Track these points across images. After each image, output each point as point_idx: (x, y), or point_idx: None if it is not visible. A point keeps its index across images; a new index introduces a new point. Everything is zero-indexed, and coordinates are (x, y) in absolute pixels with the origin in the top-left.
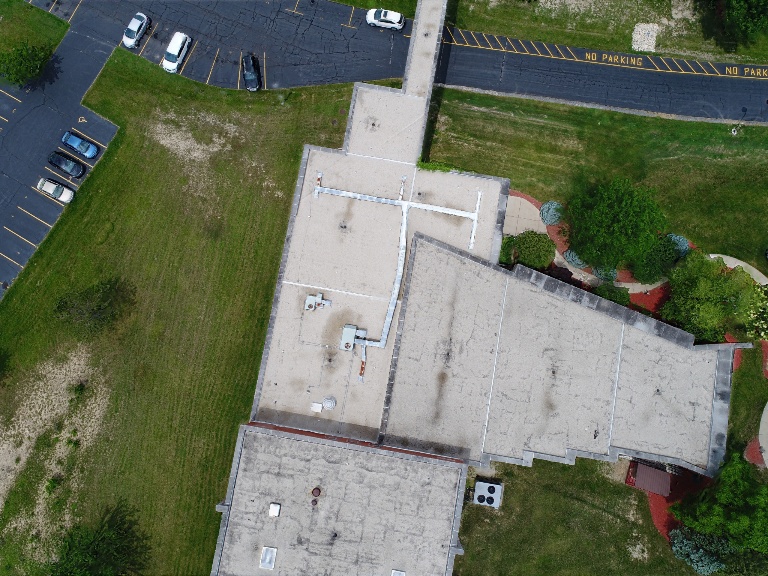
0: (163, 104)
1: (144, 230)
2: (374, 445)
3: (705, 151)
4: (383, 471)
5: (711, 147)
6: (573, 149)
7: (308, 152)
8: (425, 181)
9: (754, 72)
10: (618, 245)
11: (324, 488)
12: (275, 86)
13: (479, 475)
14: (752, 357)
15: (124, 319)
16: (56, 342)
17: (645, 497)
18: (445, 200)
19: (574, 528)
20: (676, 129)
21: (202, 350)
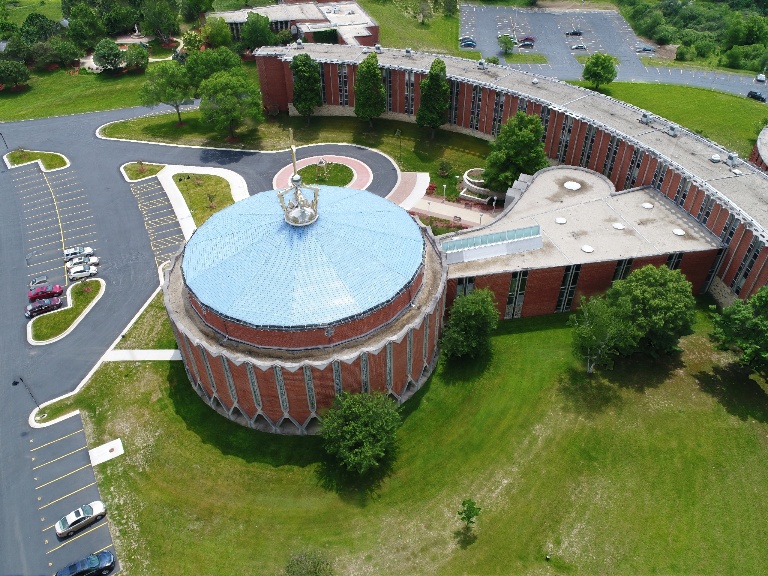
0: None
1: None
2: None
3: None
4: None
5: None
6: None
7: None
8: None
9: None
10: None
11: None
12: None
13: None
14: None
15: None
16: None
17: None
18: None
19: None
20: None
21: None
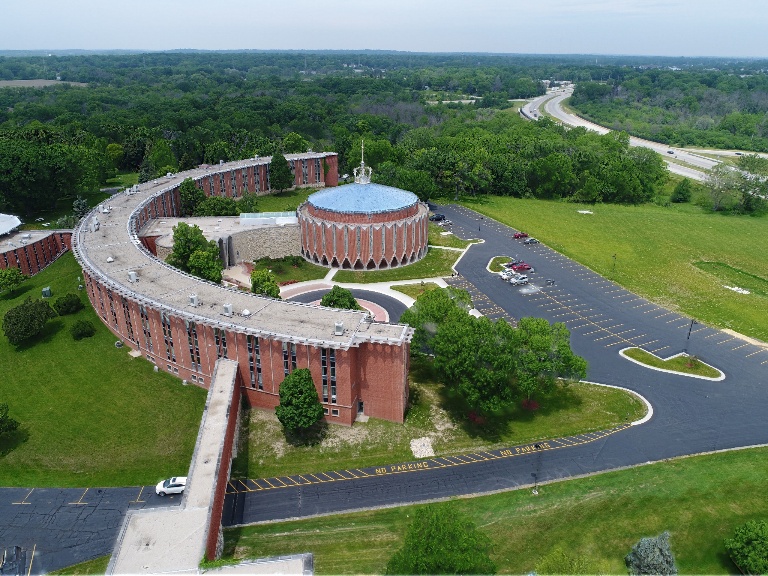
0: None
1: None
2: None
3: (518, 511)
4: None
5: (522, 508)
6: (388, 540)
7: None
8: None
9: (524, 449)
10: (442, 563)
11: None
12: (41, 572)
13: None
14: None
15: None
16: None
17: None
18: None
19: None
20: (482, 503)
21: None
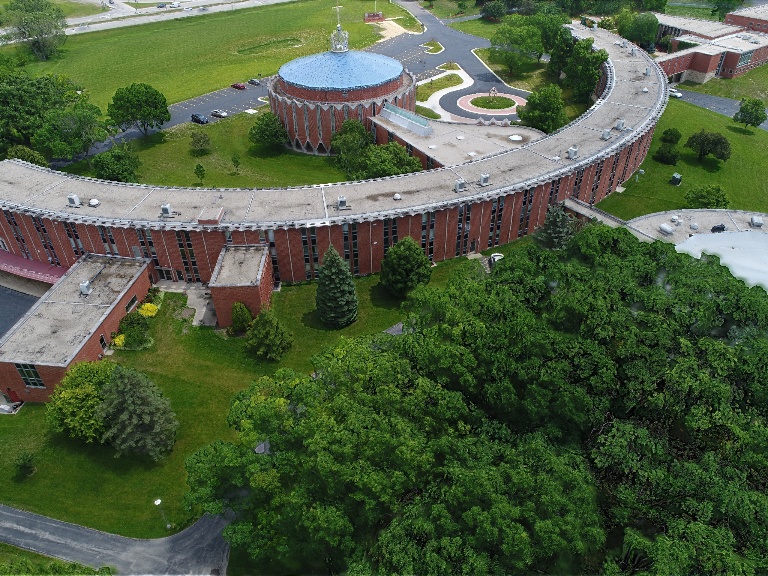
0: None
1: None
2: (751, 26)
3: None
4: None
5: None
6: None
7: None
8: None
9: None
10: None
11: None
12: None
13: None
14: None
15: None
16: None
17: None
18: None
19: None
20: None
21: None
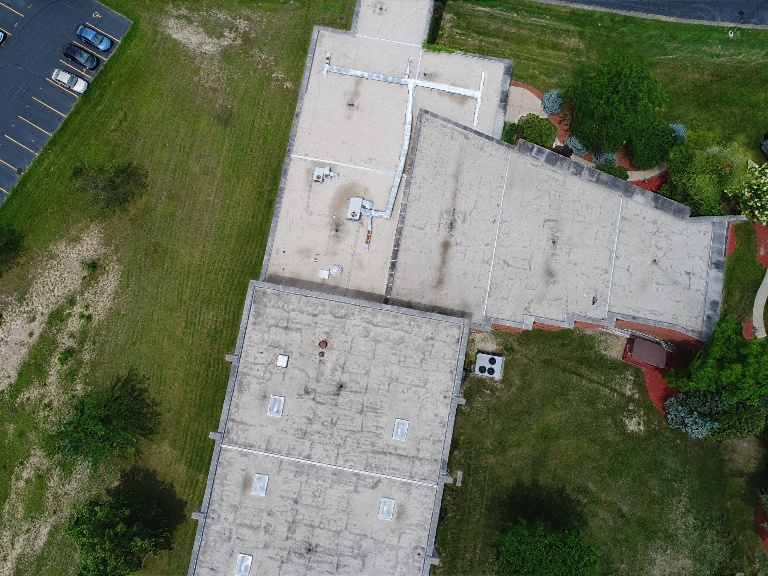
0: (175, 1)
1: (156, 118)
2: None
3: (702, 51)
4: (388, 326)
5: (708, 48)
6: (574, 47)
7: (317, 33)
8: (431, 62)
9: None
10: (617, 115)
11: (331, 341)
12: None
13: (480, 350)
14: (746, 242)
15: (136, 201)
16: (69, 223)
17: (641, 373)
18: (450, 80)
19: (572, 401)
20: (674, 31)
21: (212, 229)
